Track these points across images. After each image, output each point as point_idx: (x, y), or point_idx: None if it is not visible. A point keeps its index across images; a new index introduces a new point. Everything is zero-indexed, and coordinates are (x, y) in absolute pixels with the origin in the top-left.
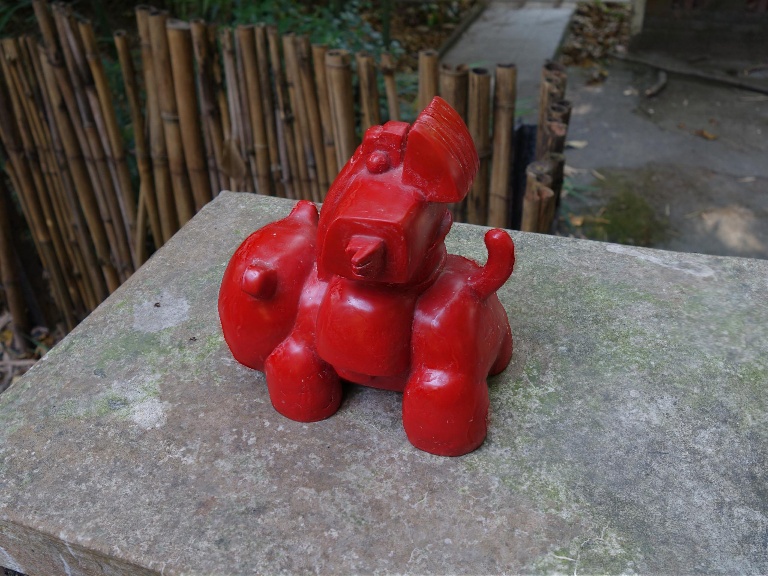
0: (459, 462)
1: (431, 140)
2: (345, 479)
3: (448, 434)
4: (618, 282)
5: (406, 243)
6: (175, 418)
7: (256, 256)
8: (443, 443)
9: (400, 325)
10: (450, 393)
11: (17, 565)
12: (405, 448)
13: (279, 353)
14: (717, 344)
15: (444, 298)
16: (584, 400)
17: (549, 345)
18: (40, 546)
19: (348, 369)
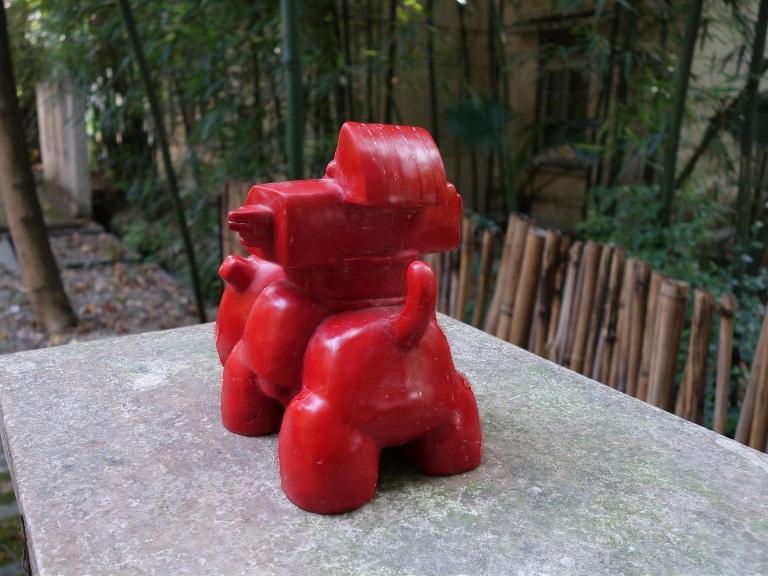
0: (300, 515)
1: (355, 136)
2: (197, 476)
3: (295, 470)
4: (689, 469)
5: (288, 219)
6: (157, 390)
7: (254, 256)
8: (291, 481)
9: (294, 328)
10: (313, 422)
11: (7, 459)
12: (273, 483)
13: (234, 350)
14: (756, 574)
15: (351, 321)
16: (498, 537)
17: (525, 480)
18: (3, 430)
19: (247, 363)
